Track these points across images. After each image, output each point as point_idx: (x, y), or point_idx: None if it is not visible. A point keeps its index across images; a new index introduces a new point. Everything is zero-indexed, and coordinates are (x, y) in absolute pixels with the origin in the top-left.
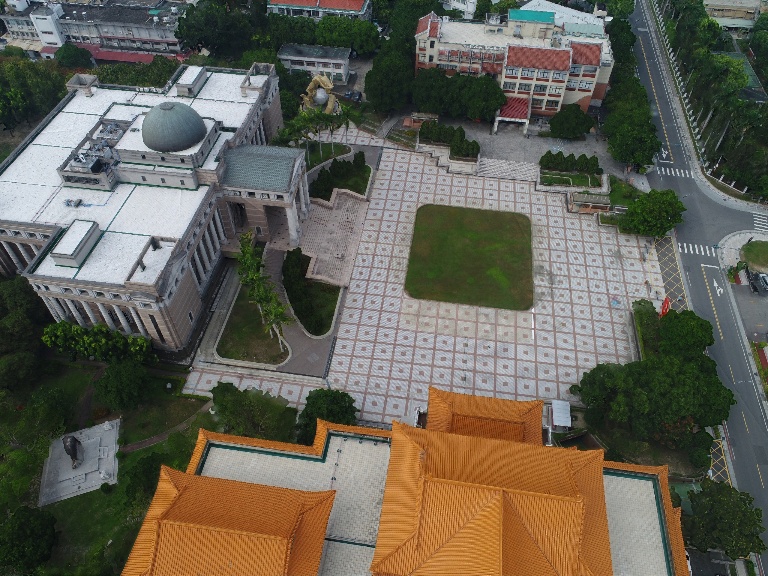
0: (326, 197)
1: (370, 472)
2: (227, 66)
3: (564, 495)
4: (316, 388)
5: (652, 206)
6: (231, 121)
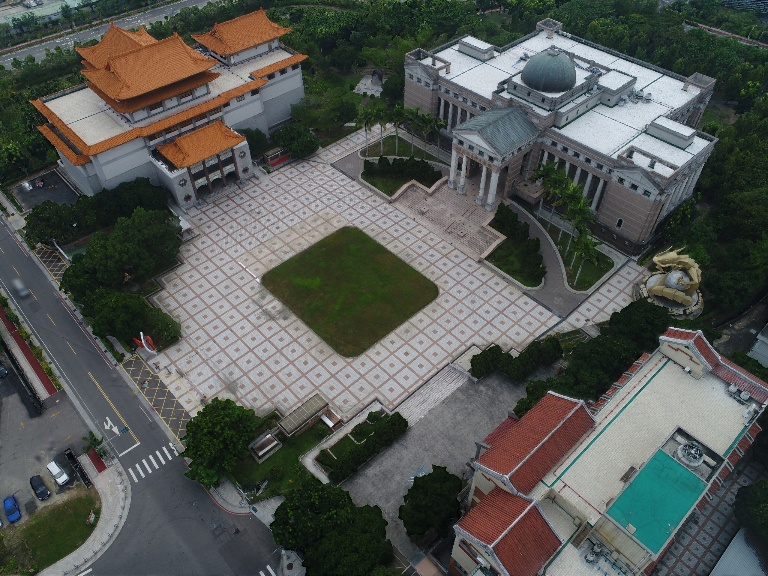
0: (497, 227)
1: (226, 84)
2: (766, 212)
3: (119, 61)
4: (328, 159)
5: (217, 404)
6: (584, 137)
